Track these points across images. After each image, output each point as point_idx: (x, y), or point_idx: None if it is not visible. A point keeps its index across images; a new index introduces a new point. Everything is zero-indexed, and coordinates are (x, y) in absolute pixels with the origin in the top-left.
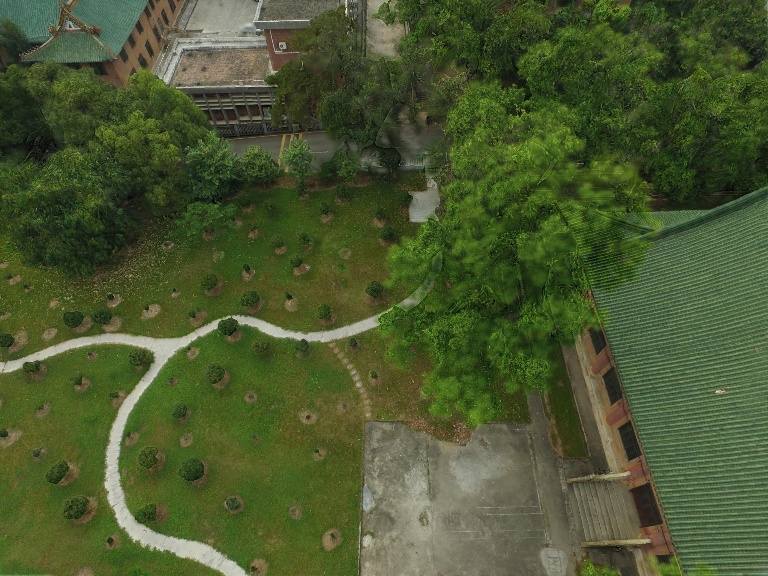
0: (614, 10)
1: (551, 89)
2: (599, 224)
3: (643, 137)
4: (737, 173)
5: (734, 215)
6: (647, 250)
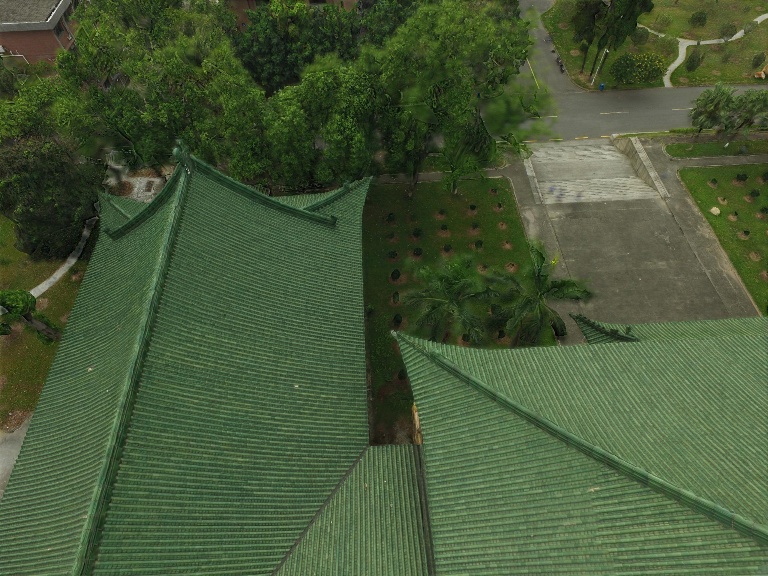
0: (292, 6)
1: (100, 86)
2: (116, 215)
3: (200, 130)
4: (309, 162)
5: (167, 202)
6: (127, 238)
